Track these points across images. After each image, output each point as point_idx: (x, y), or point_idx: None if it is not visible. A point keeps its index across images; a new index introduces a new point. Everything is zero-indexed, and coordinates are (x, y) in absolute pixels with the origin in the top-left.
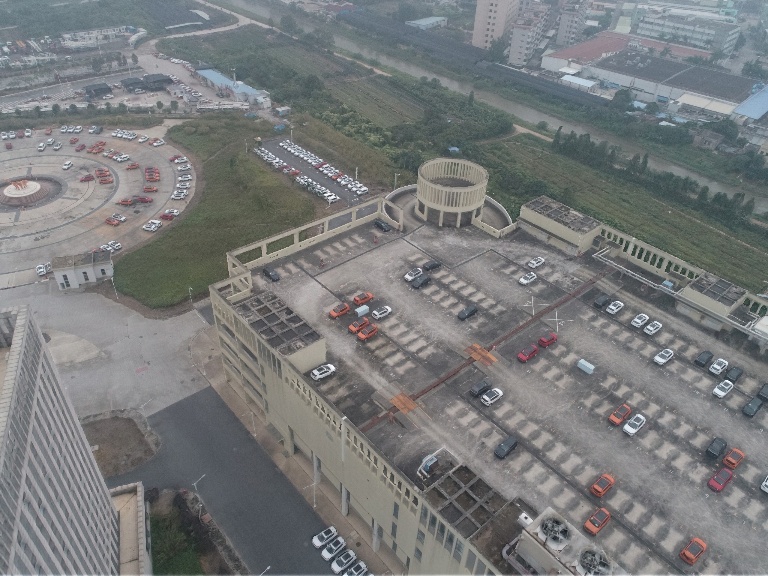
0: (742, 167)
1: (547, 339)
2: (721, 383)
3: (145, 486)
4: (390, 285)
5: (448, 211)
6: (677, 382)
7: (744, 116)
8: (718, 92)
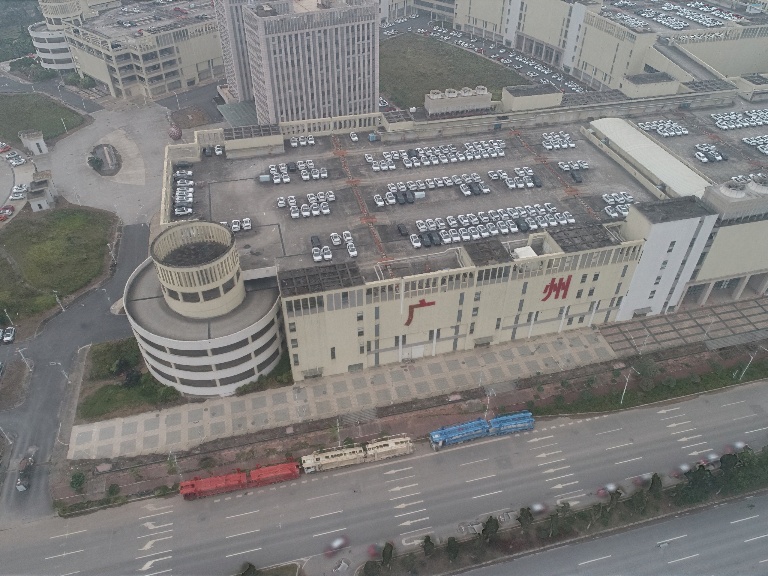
0: (6, 3)
1: (178, 7)
2: None
3: None
4: (132, 29)
5: None
6: None
7: None
8: None
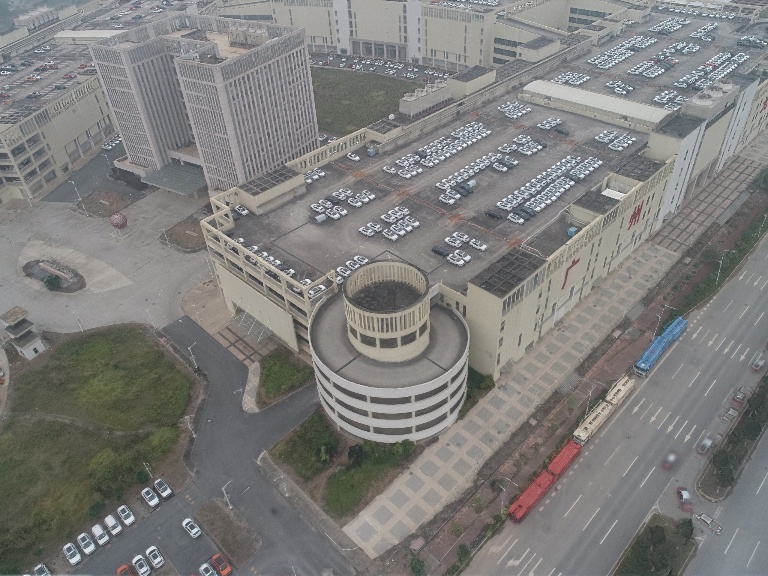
0: None
1: None
2: (4, 72)
3: (112, 184)
4: None
5: None
6: (5, 79)
7: None
8: None
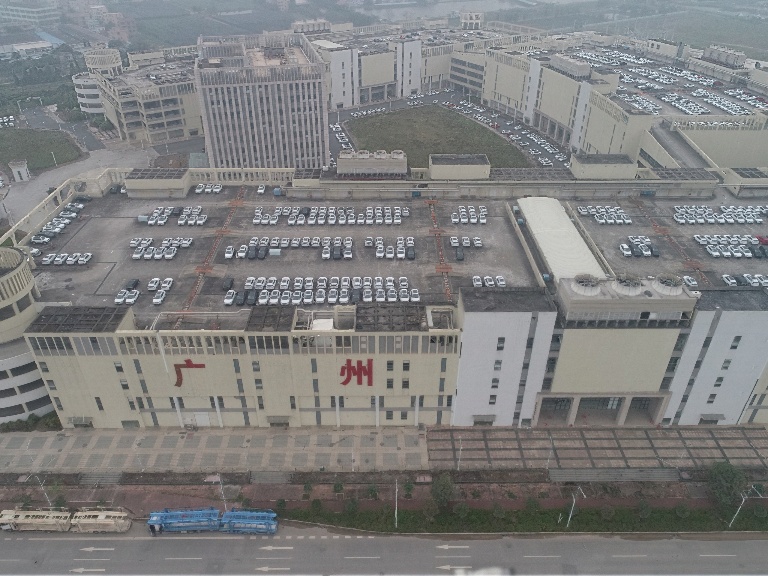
0: None
1: None
2: None
3: None
4: None
5: (118, 65)
6: None
7: (60, 43)
8: (25, 40)
